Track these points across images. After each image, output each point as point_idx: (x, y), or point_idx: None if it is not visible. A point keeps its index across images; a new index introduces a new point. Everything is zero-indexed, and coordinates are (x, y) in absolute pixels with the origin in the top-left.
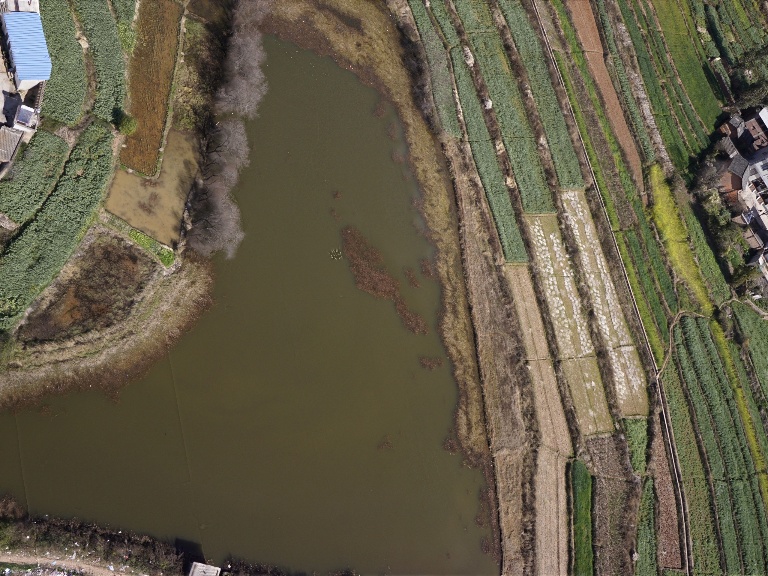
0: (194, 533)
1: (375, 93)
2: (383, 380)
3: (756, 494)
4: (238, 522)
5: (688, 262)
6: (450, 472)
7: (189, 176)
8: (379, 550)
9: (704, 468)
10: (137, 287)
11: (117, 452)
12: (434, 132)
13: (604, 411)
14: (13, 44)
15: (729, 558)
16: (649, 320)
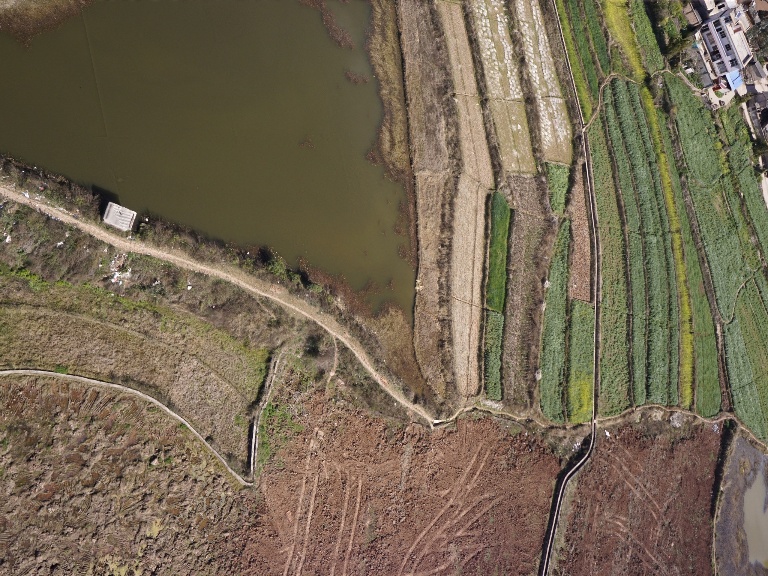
0: (111, 184)
1: None
2: (306, 83)
3: (668, 250)
4: (156, 183)
5: (624, 27)
6: (371, 181)
7: None
8: (297, 235)
9: (621, 220)
10: None
11: (30, 95)
12: None
13: (528, 154)
14: None
15: (636, 300)
16: (580, 76)
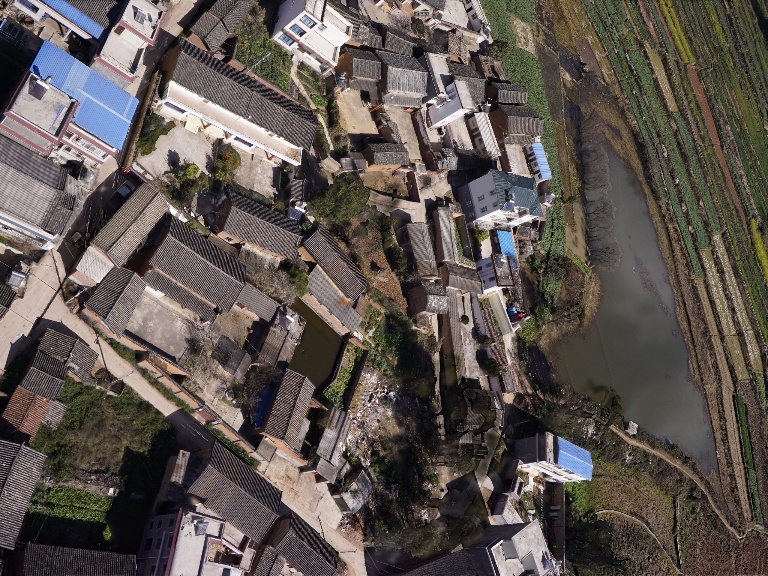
0: None
1: (632, 175)
2: (661, 341)
3: None
4: (629, 407)
5: None
6: (690, 394)
7: (584, 226)
8: (674, 429)
9: None
10: (581, 285)
11: (591, 367)
12: (656, 198)
13: (744, 368)
14: (538, 161)
15: None
16: (759, 315)
